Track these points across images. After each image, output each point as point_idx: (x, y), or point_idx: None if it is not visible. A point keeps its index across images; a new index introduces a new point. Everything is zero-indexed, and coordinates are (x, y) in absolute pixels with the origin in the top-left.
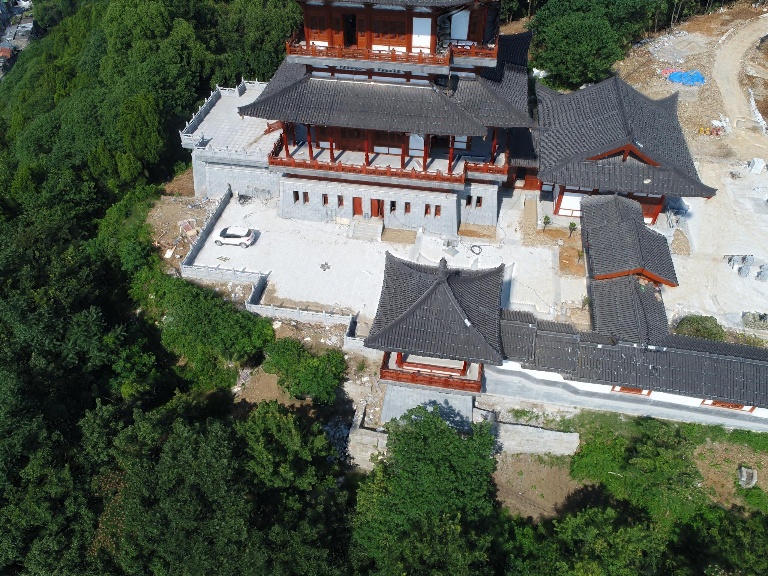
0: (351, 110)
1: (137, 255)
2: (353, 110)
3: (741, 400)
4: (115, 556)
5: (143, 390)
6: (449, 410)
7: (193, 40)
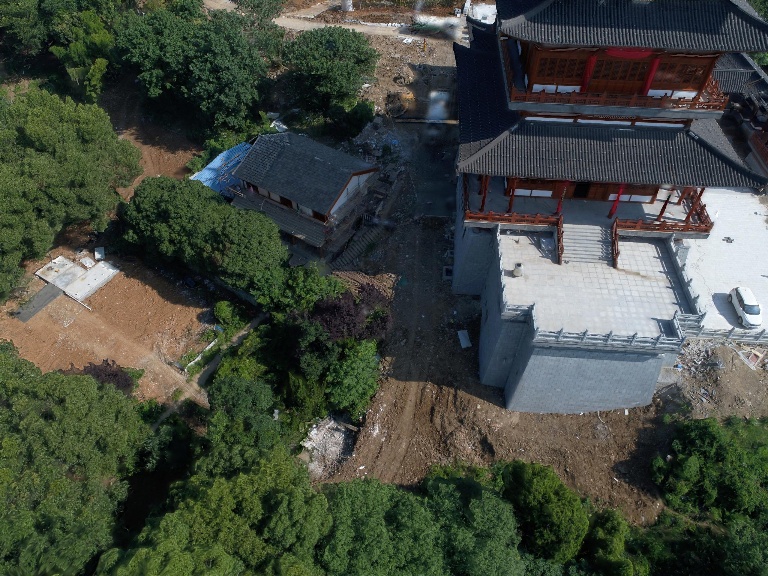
0: None
1: None
2: None
3: None
4: None
5: None
6: None
7: None
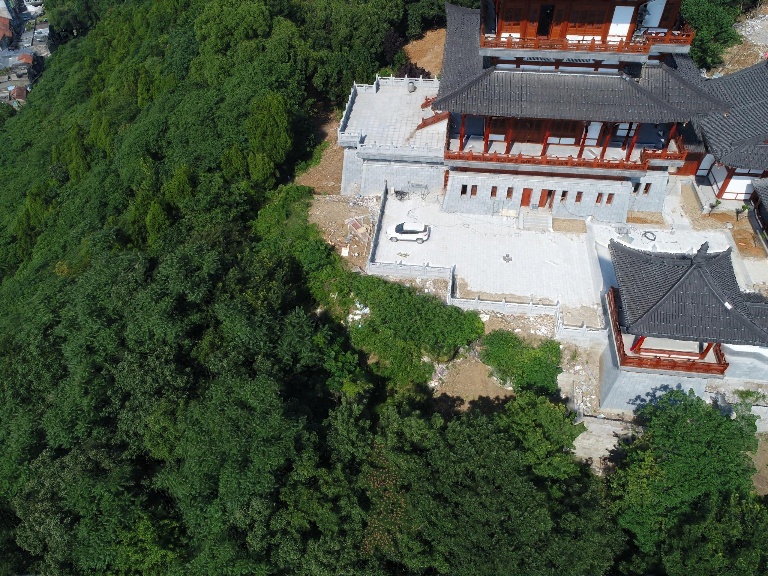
0: (542, 101)
1: (322, 254)
2: (545, 101)
3: None
4: (386, 553)
5: (367, 388)
6: None
7: (297, 38)
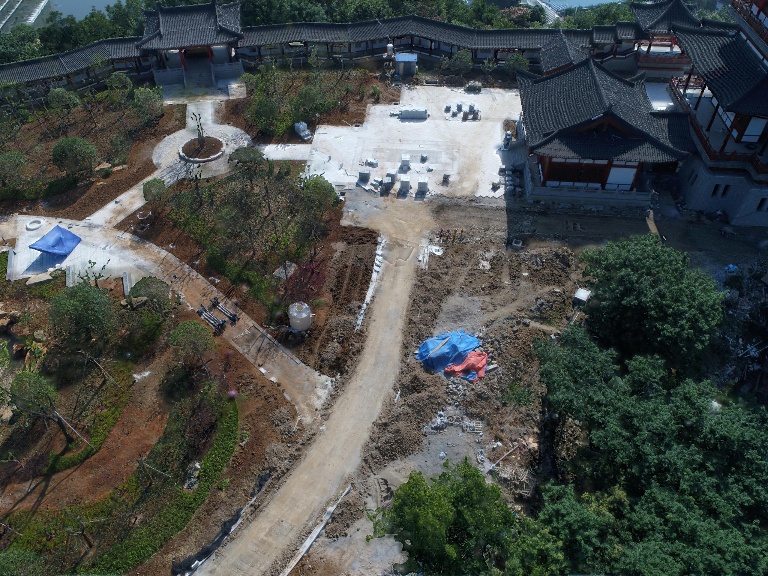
0: None
1: None
2: None
3: None
4: None
5: None
6: None
7: None
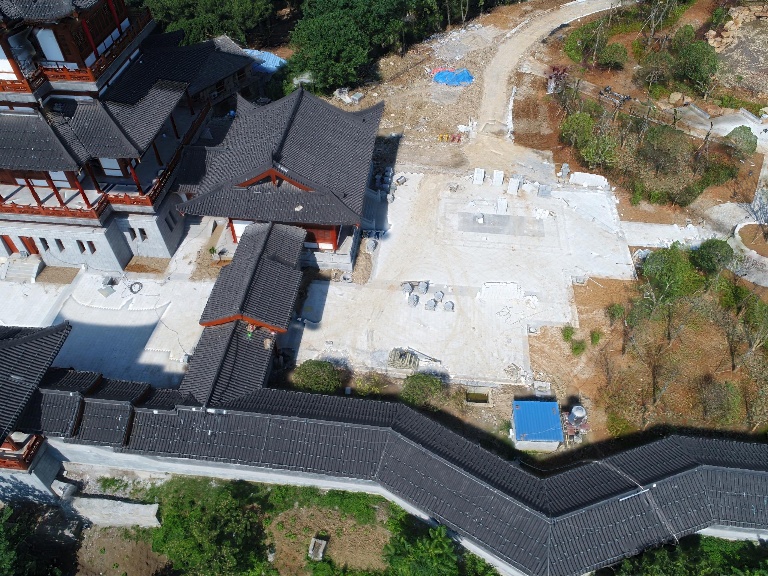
0: None
1: None
2: None
3: (300, 466)
4: None
5: None
6: (22, 485)
7: None
